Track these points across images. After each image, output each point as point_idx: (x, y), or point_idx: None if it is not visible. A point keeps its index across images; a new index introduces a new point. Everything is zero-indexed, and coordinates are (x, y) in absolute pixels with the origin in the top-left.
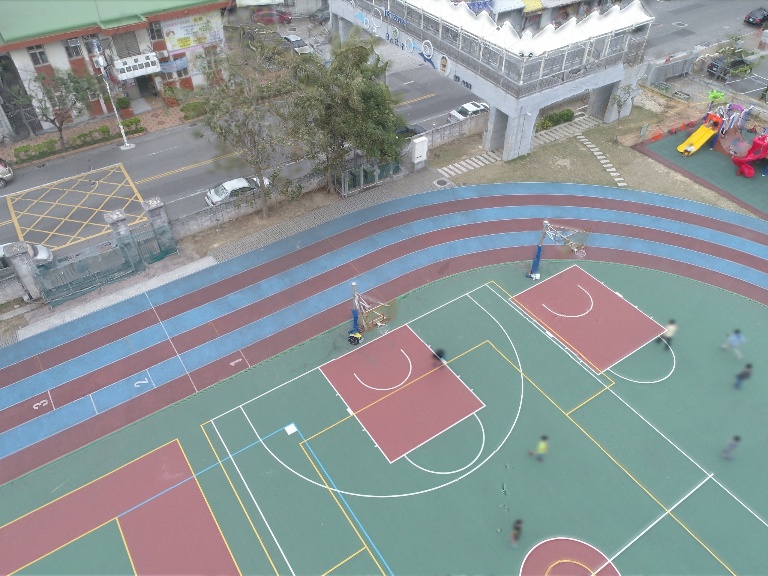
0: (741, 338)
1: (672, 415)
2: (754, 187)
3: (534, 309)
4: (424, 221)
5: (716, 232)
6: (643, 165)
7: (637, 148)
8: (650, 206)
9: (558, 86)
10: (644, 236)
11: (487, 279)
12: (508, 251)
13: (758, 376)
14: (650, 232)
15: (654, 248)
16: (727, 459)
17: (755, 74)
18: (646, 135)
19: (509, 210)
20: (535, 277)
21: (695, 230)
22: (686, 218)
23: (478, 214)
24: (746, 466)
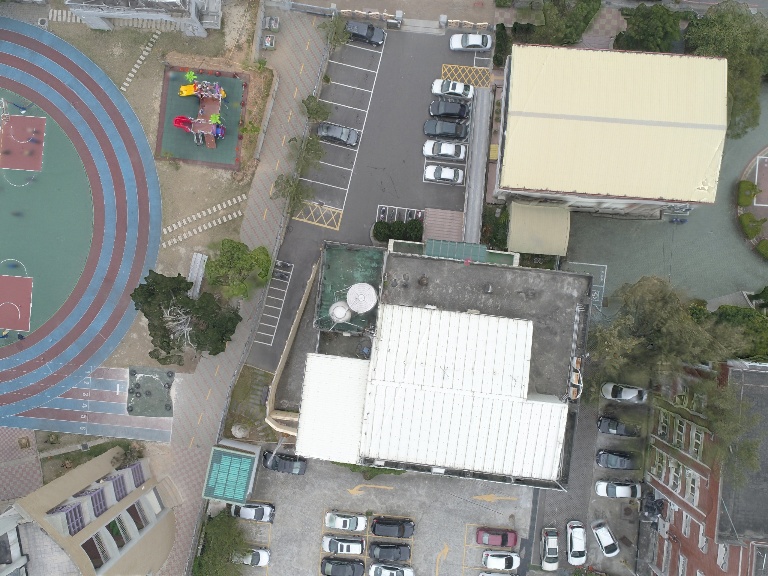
0: (62, 194)
1: (3, 198)
2: (180, 138)
3: (6, 126)
4: (10, 44)
5: (124, 147)
6: (152, 83)
7: (165, 69)
8: (117, 112)
9: (100, 12)
10: (92, 125)
11: (5, 98)
12: (27, 90)
13: (47, 209)
14: (97, 125)
15: (87, 134)
16: (2, 221)
17: (382, 50)
18: (186, 63)
19: (53, 65)
20: (21, 112)
21: (117, 139)
22: (123, 130)
23: (37, 57)
24: (4, 226)
